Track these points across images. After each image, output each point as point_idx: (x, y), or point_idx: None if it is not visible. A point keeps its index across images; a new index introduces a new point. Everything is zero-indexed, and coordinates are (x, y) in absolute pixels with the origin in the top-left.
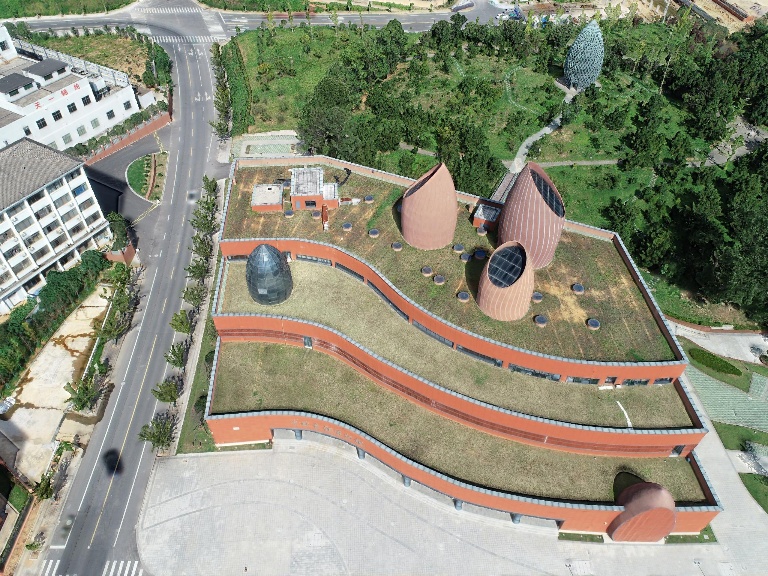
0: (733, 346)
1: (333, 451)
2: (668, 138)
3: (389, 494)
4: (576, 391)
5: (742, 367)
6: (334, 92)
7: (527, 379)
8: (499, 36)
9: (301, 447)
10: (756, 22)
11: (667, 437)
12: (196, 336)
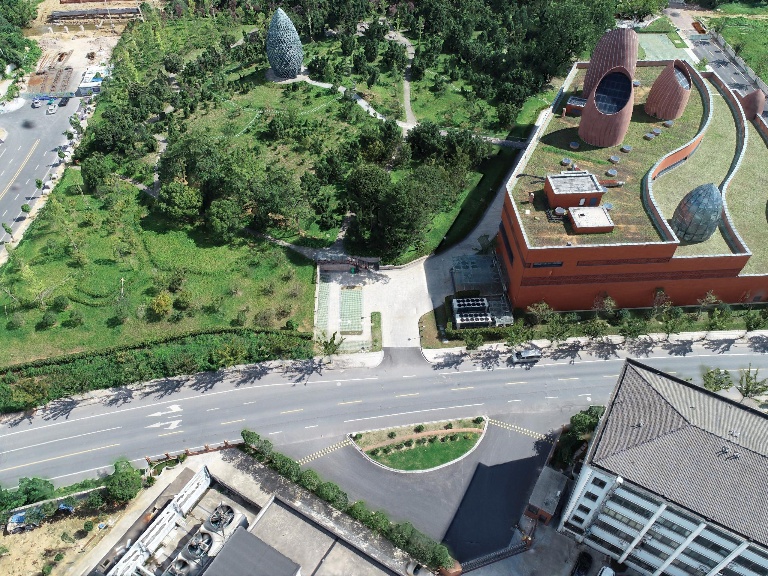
0: None
1: None
2: (379, 54)
3: None
4: None
5: None
6: None
7: None
8: (176, 94)
9: None
10: None
11: None
12: (695, 337)
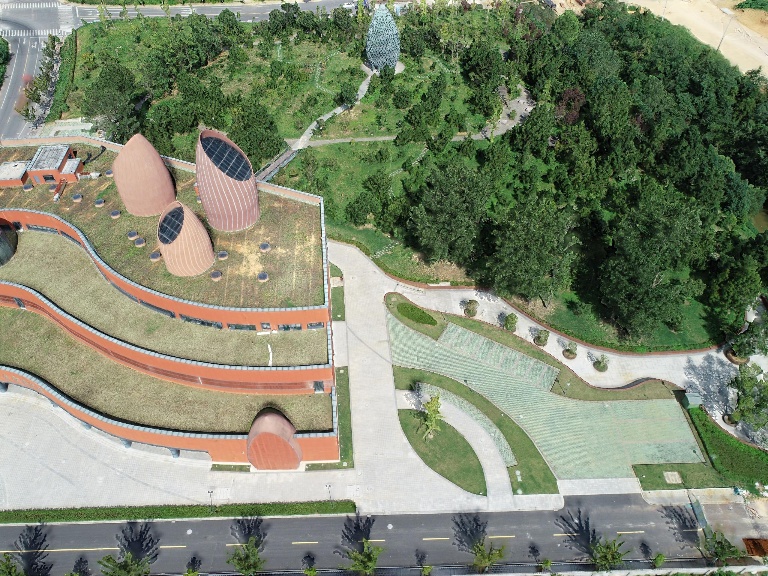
0: (444, 300)
1: (32, 401)
2: None
3: (70, 436)
4: (235, 337)
5: (441, 318)
6: (115, 76)
7: (195, 328)
8: (321, 23)
9: (4, 399)
10: (586, 6)
11: (297, 373)
12: None
